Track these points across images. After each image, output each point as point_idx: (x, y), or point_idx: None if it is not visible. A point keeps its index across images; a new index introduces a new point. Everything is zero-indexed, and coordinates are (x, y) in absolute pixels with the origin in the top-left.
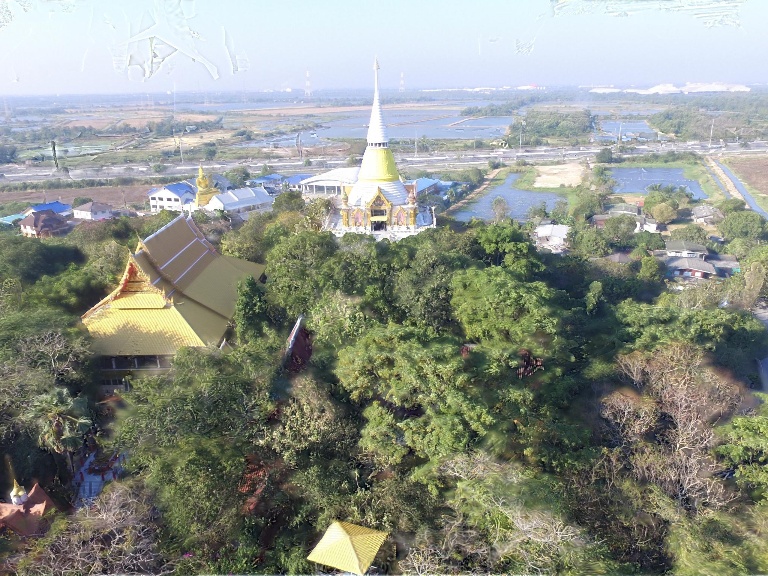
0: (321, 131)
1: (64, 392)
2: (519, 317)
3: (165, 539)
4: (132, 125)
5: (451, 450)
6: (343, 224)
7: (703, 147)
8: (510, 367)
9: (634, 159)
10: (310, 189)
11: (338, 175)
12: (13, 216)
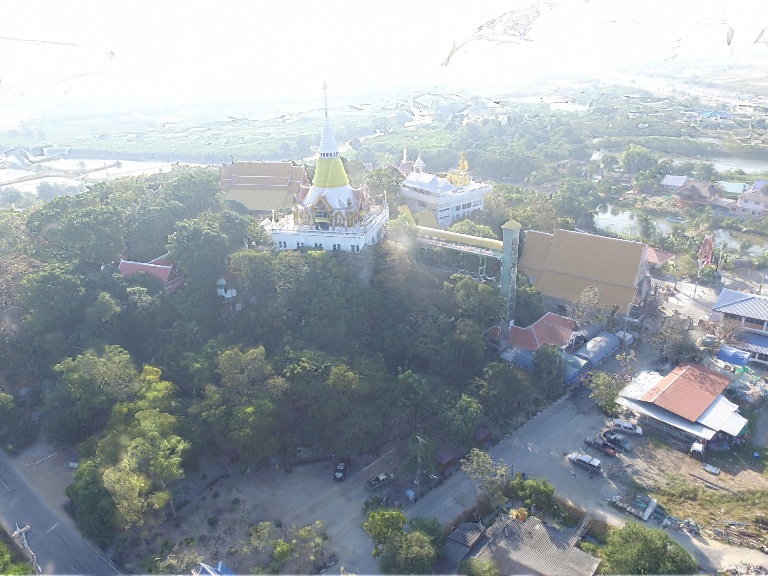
0: None
1: None
2: None
3: None
4: None
5: None
6: None
7: None
8: None
9: None
10: None
11: None
12: (739, 184)
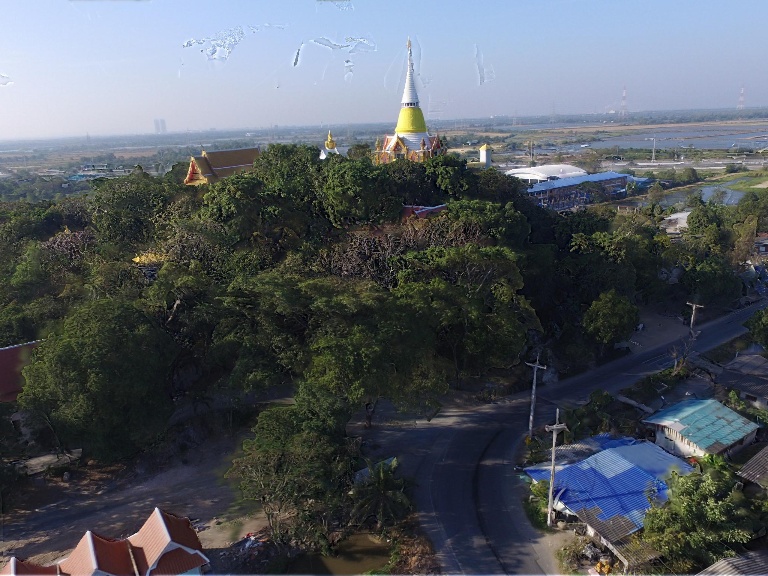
0: (595, 144)
1: (103, 197)
2: None
3: (91, 246)
4: None
5: (211, 222)
6: None
7: None
8: (282, 197)
9: None
10: None
11: (532, 169)
12: None
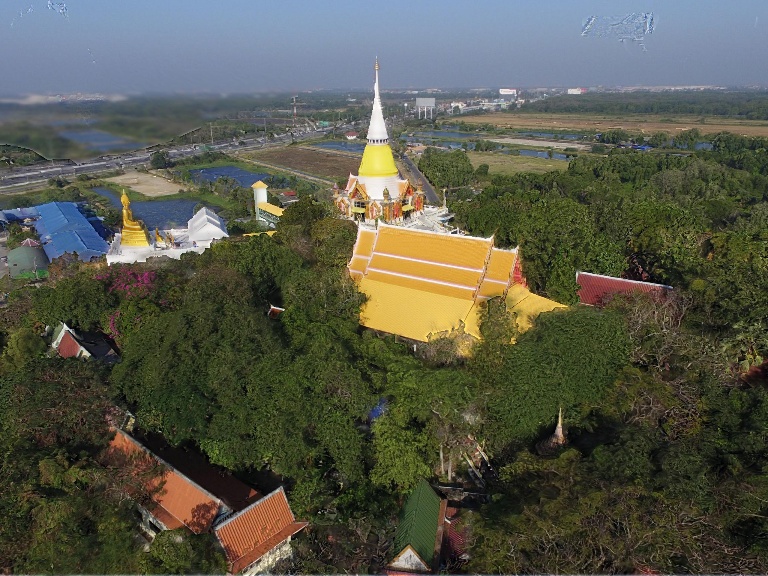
0: None
1: None
2: (684, 225)
3: None
4: None
5: None
6: (385, 219)
7: (225, 147)
8: None
9: (183, 162)
10: None
11: None
12: None
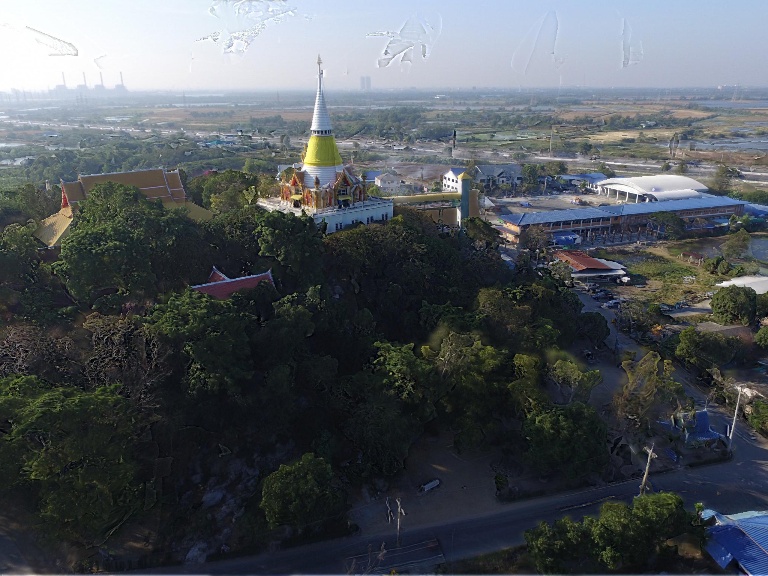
0: None
1: None
2: None
3: None
4: (591, 117)
5: None
6: None
7: None
8: None
9: None
10: (607, 192)
11: (632, 180)
12: None
